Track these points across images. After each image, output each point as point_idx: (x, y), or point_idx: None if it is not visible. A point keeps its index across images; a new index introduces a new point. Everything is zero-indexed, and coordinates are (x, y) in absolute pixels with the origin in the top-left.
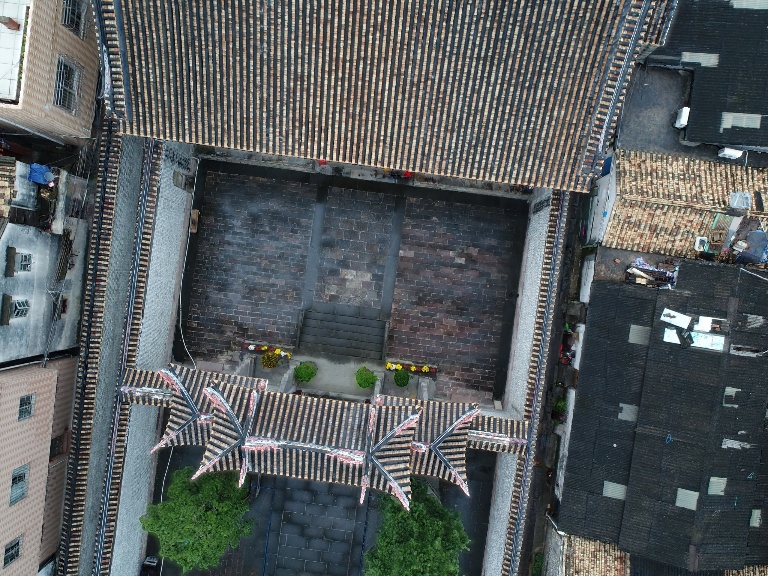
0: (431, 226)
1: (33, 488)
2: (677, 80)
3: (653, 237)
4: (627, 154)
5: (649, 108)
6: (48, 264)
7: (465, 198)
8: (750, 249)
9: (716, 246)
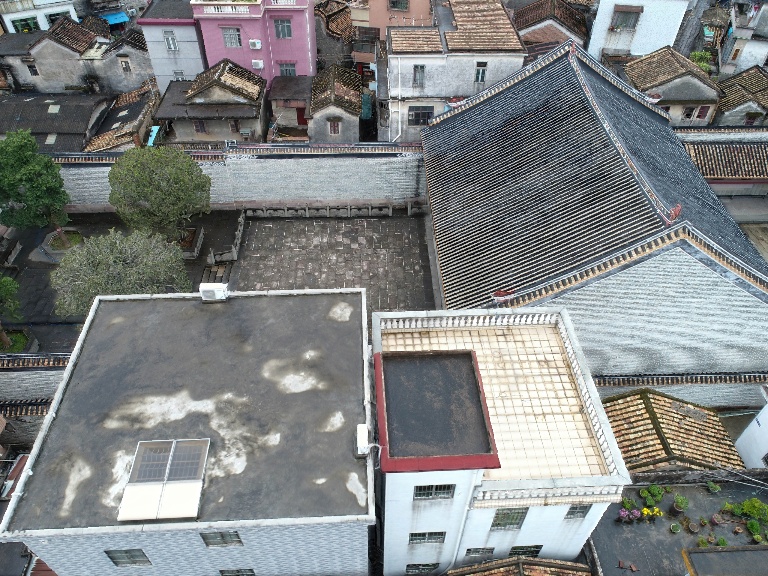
0: None
1: None
2: None
3: None
4: None
5: None
6: None
7: None
8: None
9: None
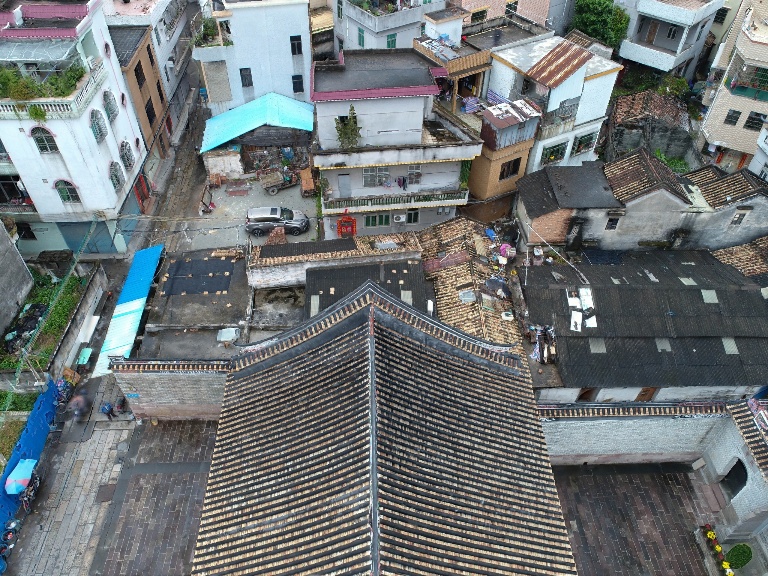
0: None
1: None
2: None
3: None
4: None
5: None
6: None
7: None
8: None
9: None
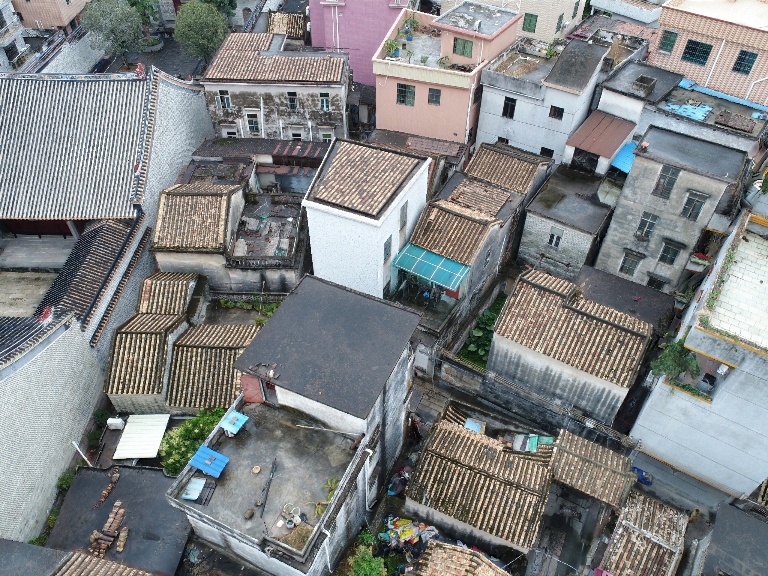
0: None
1: (78, 2)
2: None
3: None
4: None
5: None
6: None
7: None
8: None
9: None
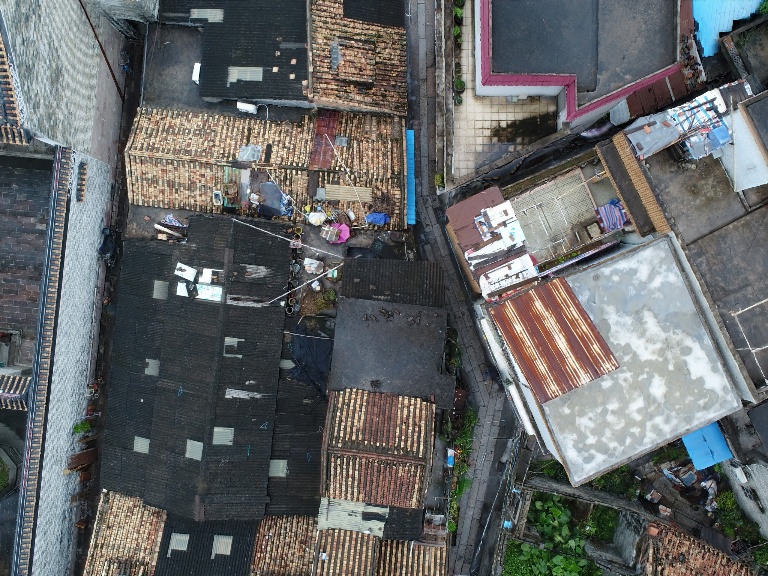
0: (12, 194)
1: None
2: (197, 37)
3: (173, 193)
4: (149, 112)
5: (171, 66)
6: None
7: (44, 165)
8: (267, 202)
9: (234, 200)
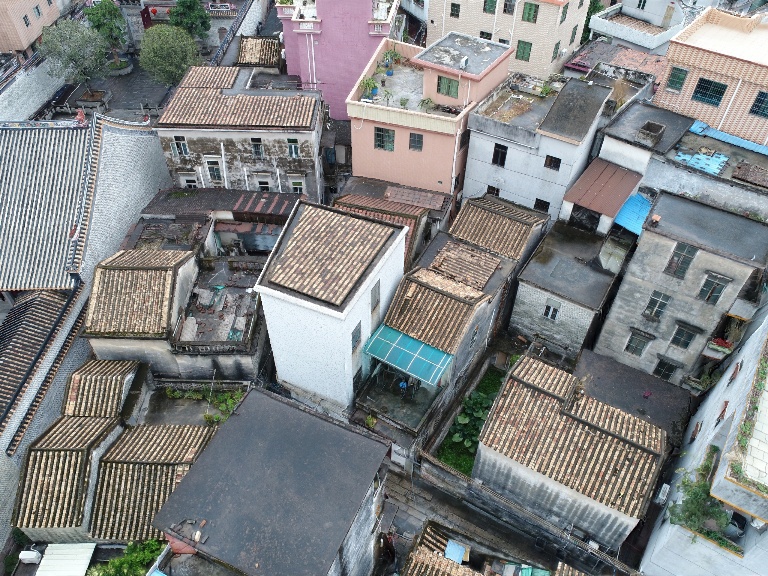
0: None
1: None
2: None
3: None
4: None
5: None
6: (67, 4)
7: None
8: None
9: None
